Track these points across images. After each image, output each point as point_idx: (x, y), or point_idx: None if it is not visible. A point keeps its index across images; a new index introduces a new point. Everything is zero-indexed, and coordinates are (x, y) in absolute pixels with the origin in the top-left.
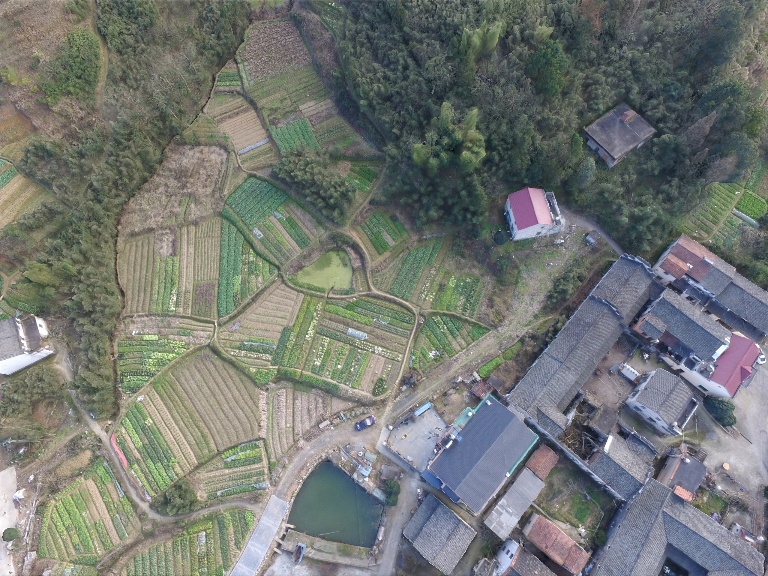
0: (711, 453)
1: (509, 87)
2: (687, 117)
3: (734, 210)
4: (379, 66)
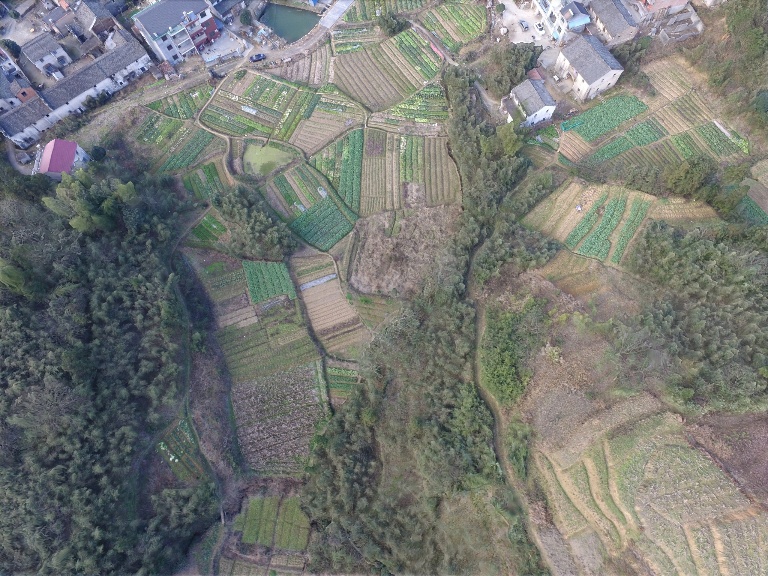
0: None
1: (1, 242)
2: None
3: None
4: None
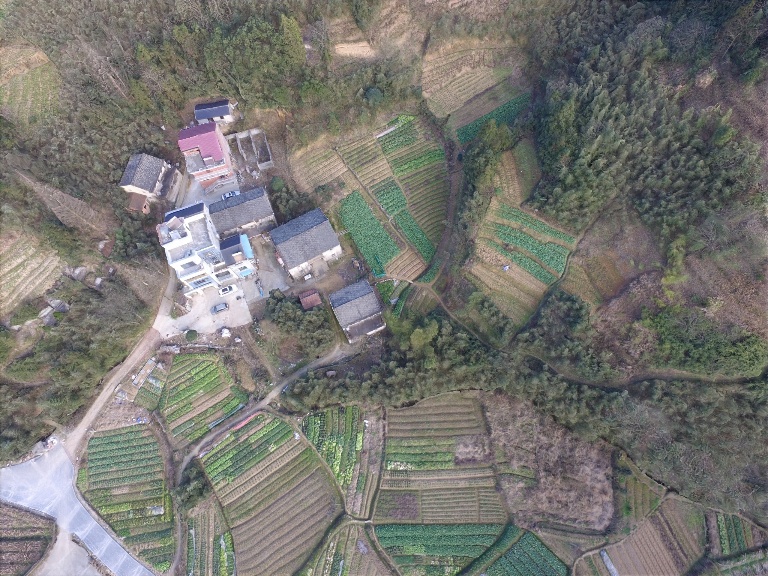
0: None
1: None
2: None
3: None
4: None
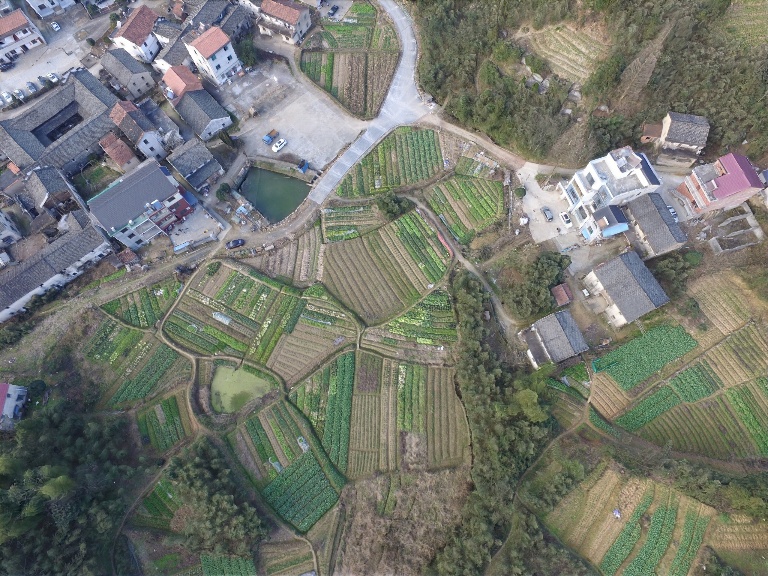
0: None
1: None
2: None
3: None
4: None
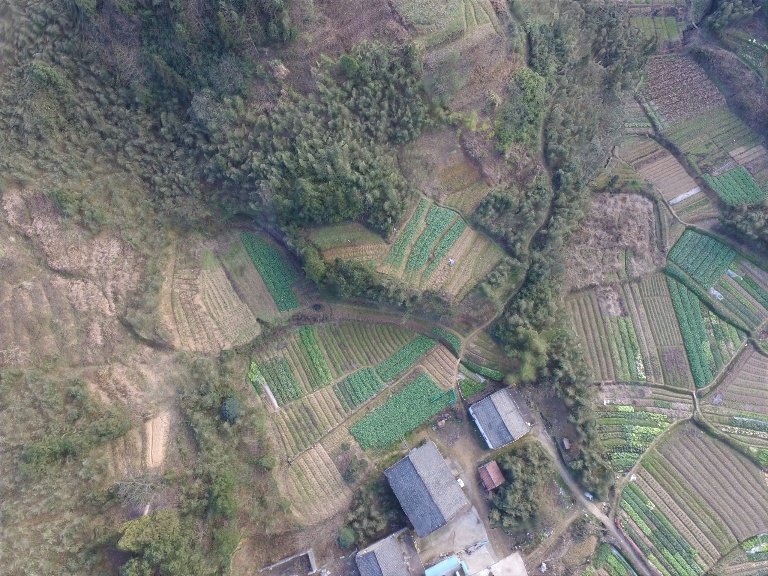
0: None
1: None
2: None
3: None
4: None
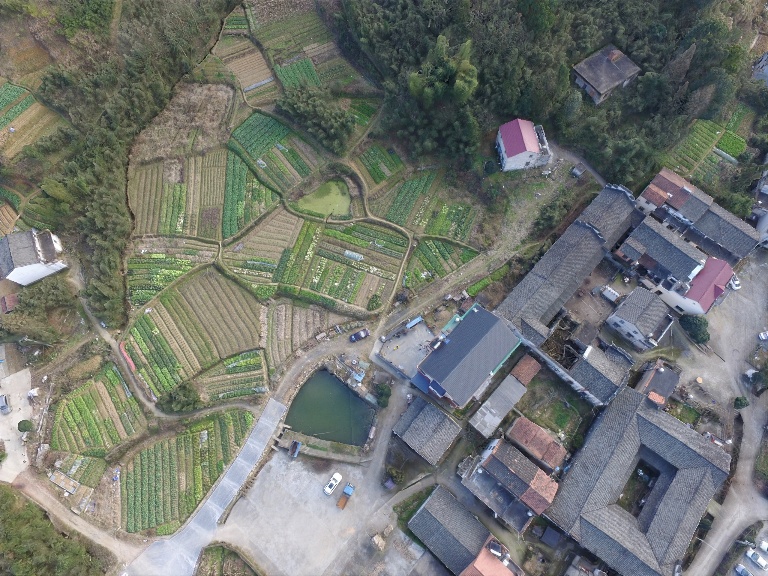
0: (686, 369)
1: (502, 23)
2: (671, 57)
3: (714, 148)
4: (379, 7)
